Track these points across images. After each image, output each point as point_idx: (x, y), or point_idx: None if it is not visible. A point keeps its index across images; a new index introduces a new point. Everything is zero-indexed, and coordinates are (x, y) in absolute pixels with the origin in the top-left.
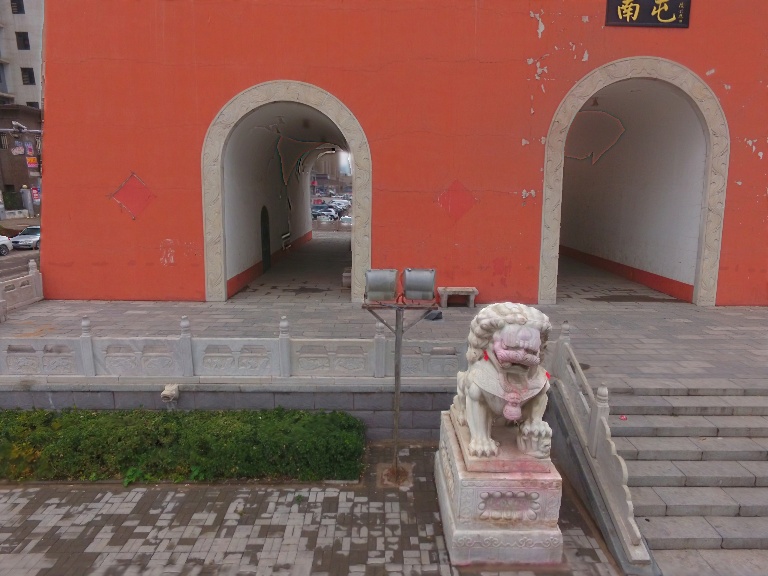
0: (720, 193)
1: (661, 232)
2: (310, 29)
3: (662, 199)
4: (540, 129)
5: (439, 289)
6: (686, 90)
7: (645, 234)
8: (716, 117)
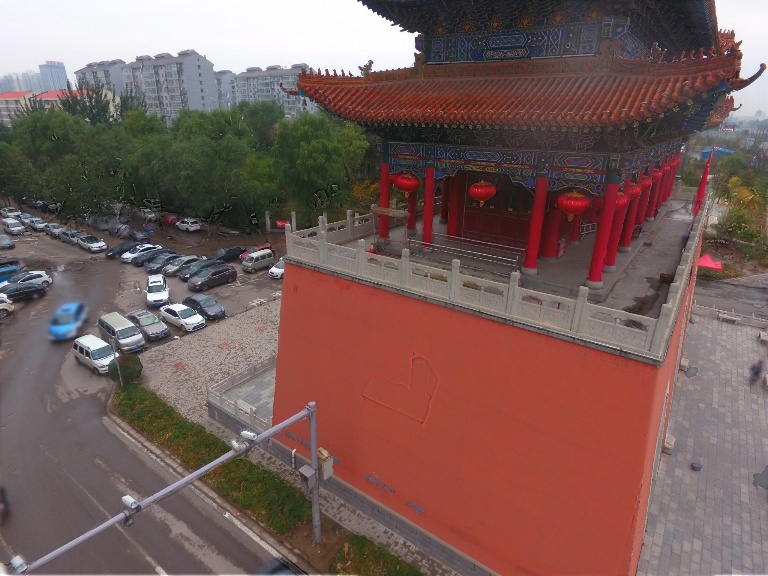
0: None
1: None
2: None
3: None
4: None
5: (670, 447)
6: None
7: None
8: None
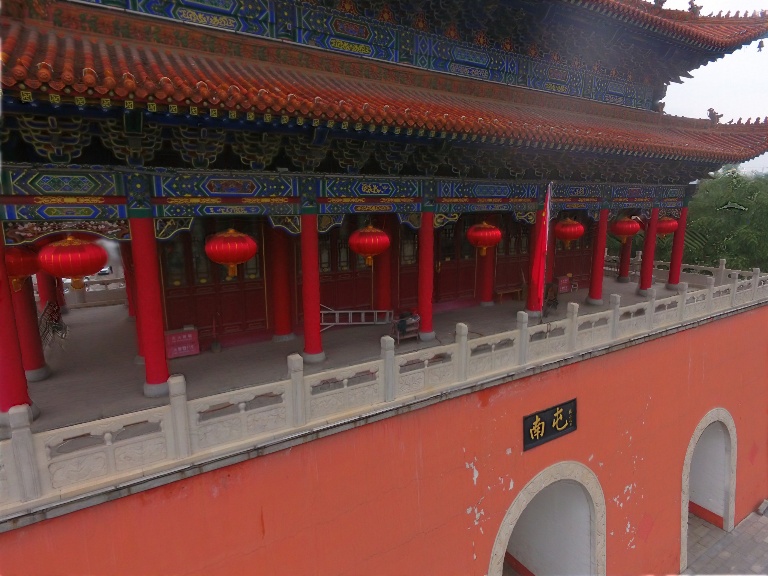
0: (603, 548)
1: (546, 550)
2: None
3: (544, 521)
4: (482, 569)
5: None
6: (579, 480)
7: (527, 538)
8: (597, 491)
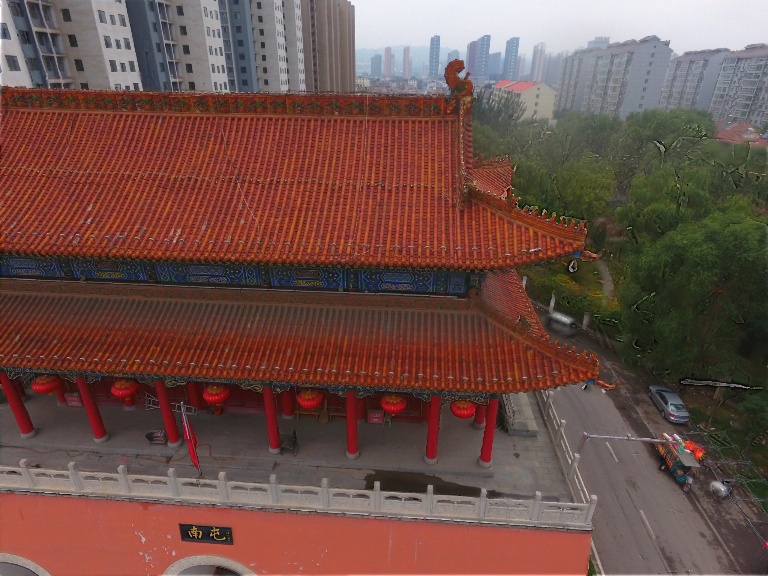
0: None
1: None
2: (8, 532)
3: None
4: None
5: None
6: (239, 572)
7: None
8: None
